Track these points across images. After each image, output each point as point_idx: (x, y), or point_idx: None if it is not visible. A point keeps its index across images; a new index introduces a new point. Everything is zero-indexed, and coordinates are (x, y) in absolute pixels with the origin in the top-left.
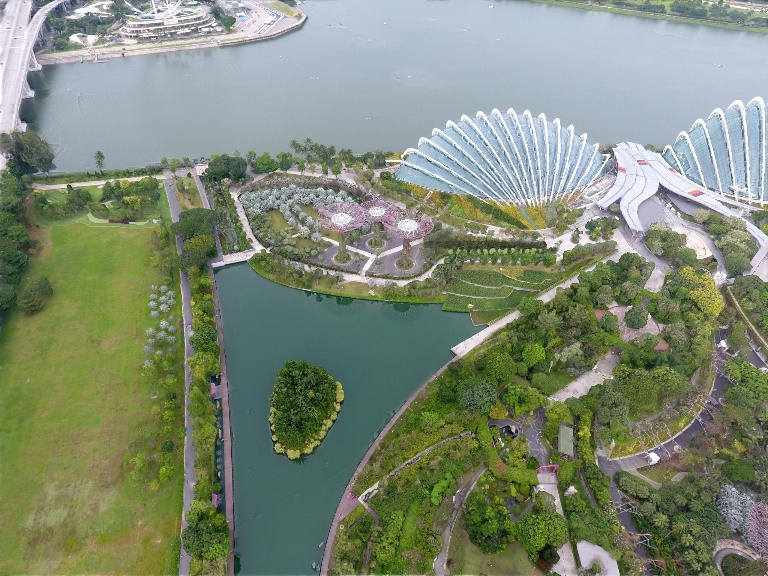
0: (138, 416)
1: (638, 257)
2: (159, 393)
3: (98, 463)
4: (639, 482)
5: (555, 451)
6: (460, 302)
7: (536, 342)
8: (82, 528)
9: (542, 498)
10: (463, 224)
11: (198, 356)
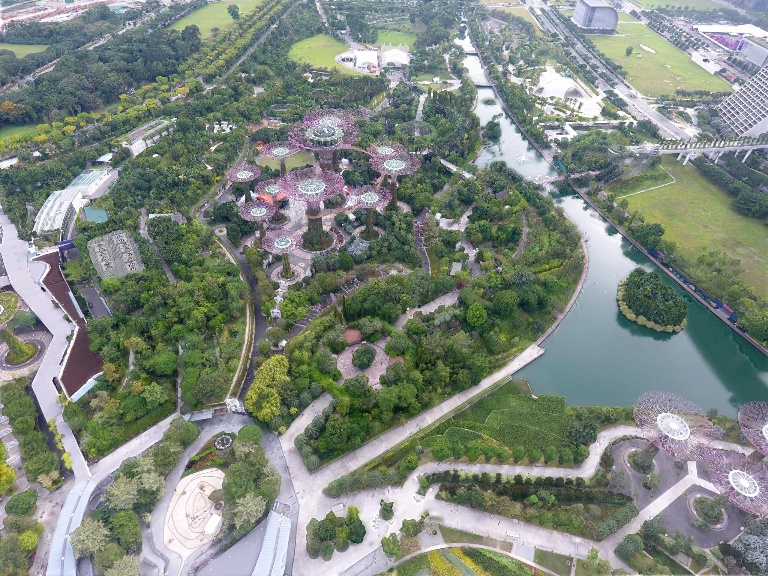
0: (762, 294)
1: (329, 424)
2: (766, 308)
3: (752, 271)
4: (411, 258)
5: (464, 264)
6: (548, 403)
7: (470, 336)
8: (721, 247)
9: None
10: (582, 570)
11: (765, 315)
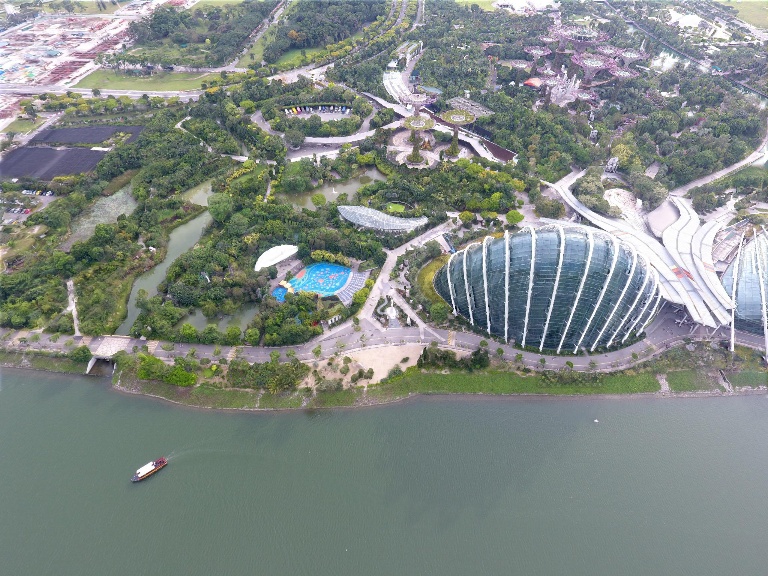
0: None
1: (678, 165)
2: None
3: None
4: None
5: None
6: None
7: None
8: None
9: (699, 96)
10: None
11: None
